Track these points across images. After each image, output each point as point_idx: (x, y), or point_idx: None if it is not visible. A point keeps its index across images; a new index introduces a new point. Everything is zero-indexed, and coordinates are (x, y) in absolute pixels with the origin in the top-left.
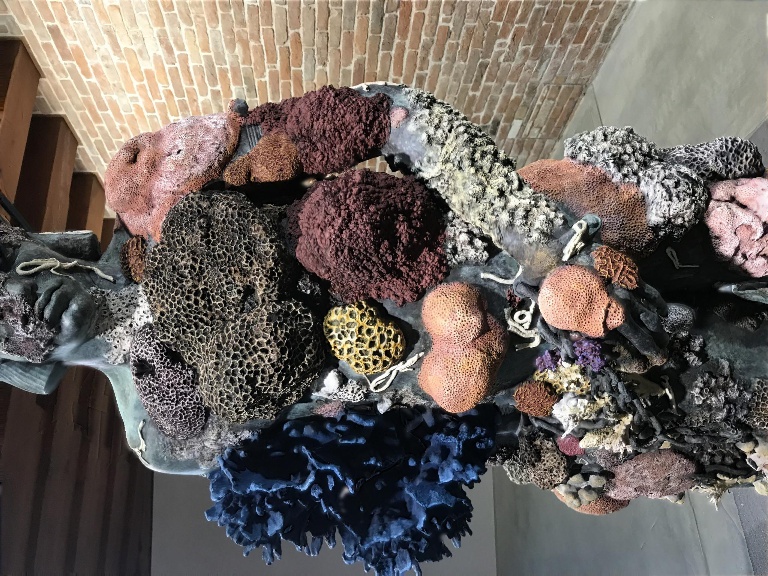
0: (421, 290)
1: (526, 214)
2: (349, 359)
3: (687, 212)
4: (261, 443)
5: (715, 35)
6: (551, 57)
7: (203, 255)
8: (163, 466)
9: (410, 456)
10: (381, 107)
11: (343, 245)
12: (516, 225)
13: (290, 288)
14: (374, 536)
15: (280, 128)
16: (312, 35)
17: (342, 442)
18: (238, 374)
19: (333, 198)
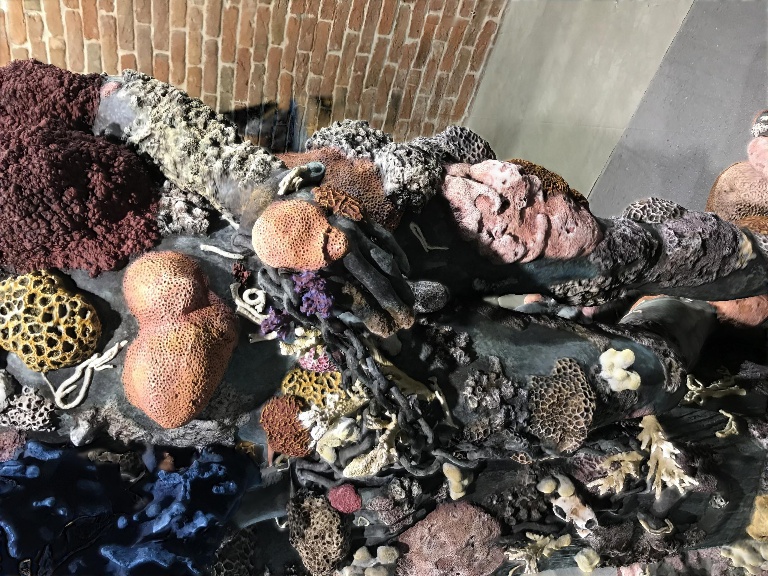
0: (121, 257)
1: (242, 161)
2: (16, 344)
3: (421, 177)
4: None
5: None
6: None
7: None
8: None
9: (121, 514)
10: (91, 82)
11: (8, 181)
12: (230, 170)
13: None
14: None
15: None
16: None
17: None
18: None
19: None
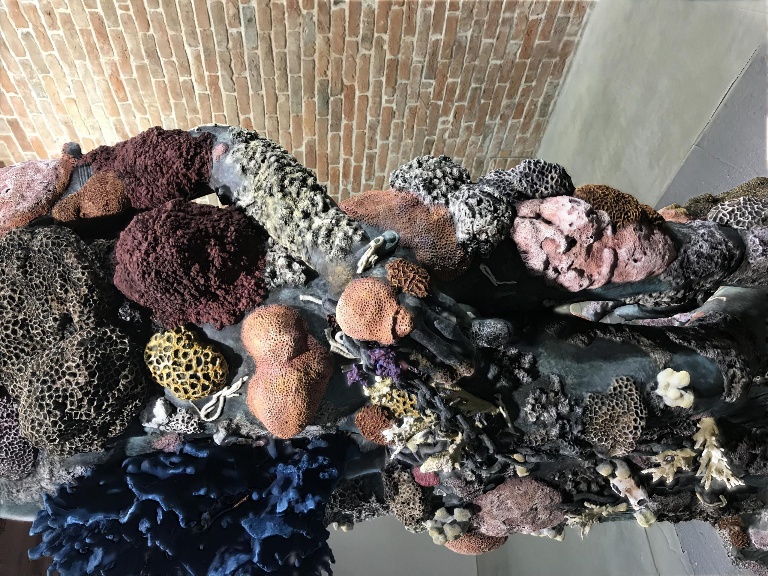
0: (239, 313)
1: (328, 233)
2: (170, 384)
3: (489, 228)
4: (94, 479)
5: (633, 103)
6: (493, 132)
7: (22, 286)
8: (1, 511)
9: (254, 490)
10: (205, 144)
11: (150, 268)
12: (318, 243)
13: (110, 316)
14: (209, 574)
15: (109, 167)
16: (262, 119)
17: (168, 472)
18: (46, 399)
19: (142, 224)
